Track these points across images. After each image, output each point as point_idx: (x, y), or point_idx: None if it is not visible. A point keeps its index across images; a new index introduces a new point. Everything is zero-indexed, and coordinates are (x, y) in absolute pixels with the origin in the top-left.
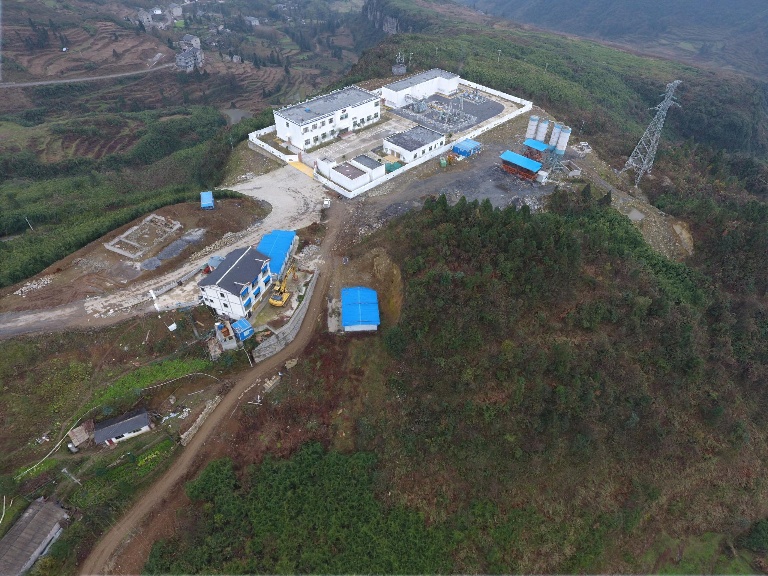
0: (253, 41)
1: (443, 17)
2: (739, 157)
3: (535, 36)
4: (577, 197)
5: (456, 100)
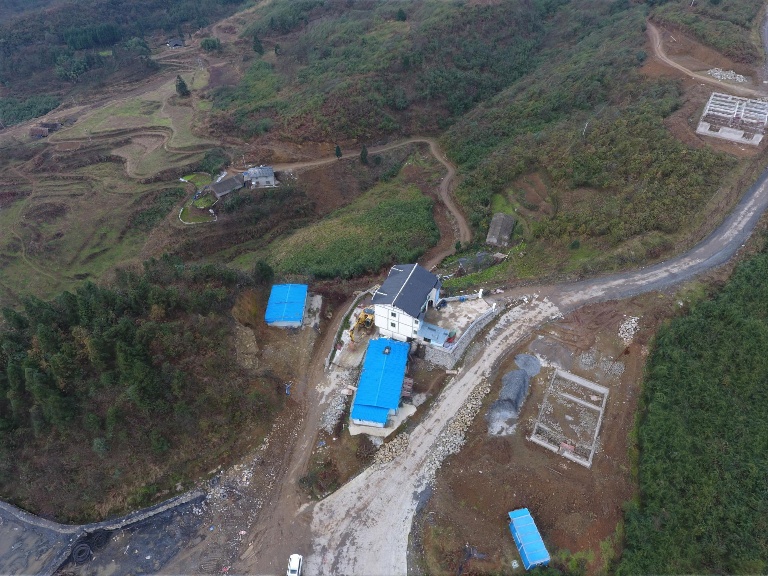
0: None
1: None
2: None
3: None
4: None
5: None
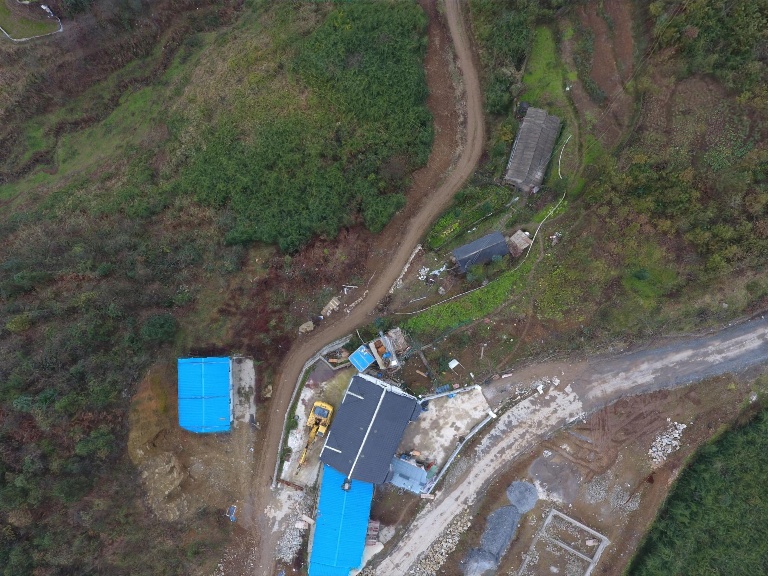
0: None
1: None
2: None
3: None
4: None
5: None
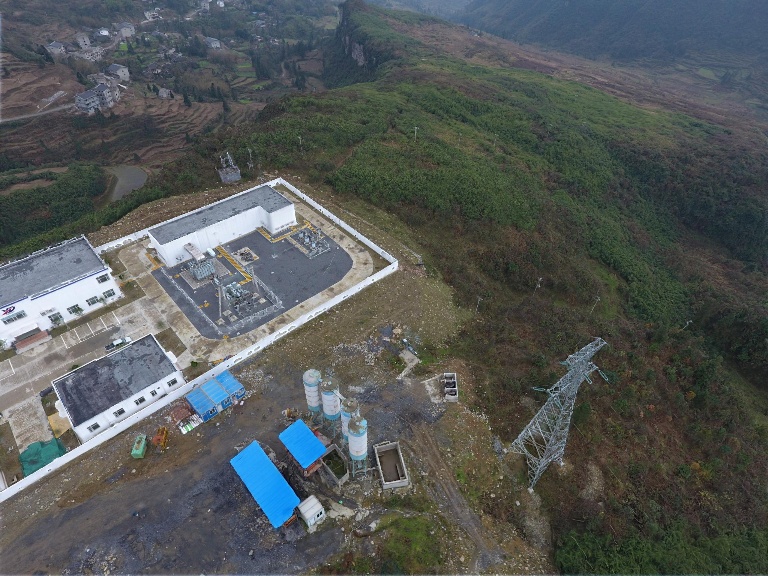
0: (205, 67)
1: (414, 46)
2: (751, 315)
3: (508, 79)
4: (378, 565)
5: (281, 246)
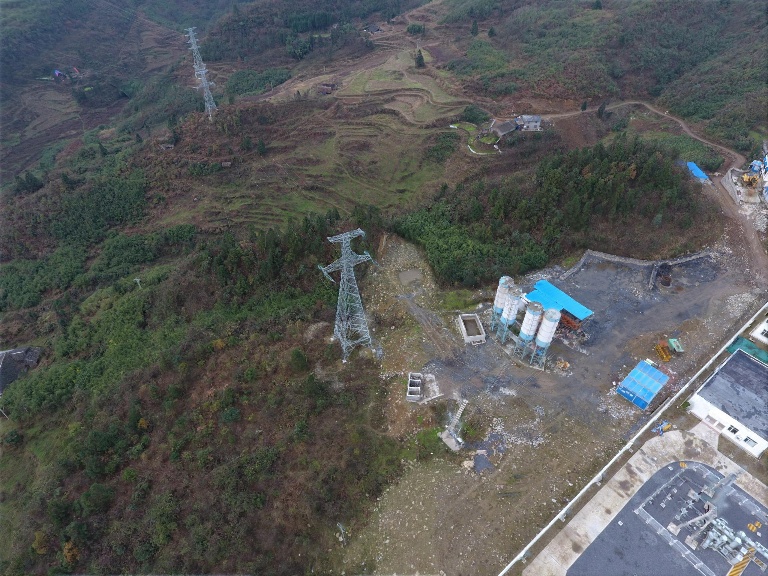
0: None
1: None
2: None
3: None
4: None
5: None
